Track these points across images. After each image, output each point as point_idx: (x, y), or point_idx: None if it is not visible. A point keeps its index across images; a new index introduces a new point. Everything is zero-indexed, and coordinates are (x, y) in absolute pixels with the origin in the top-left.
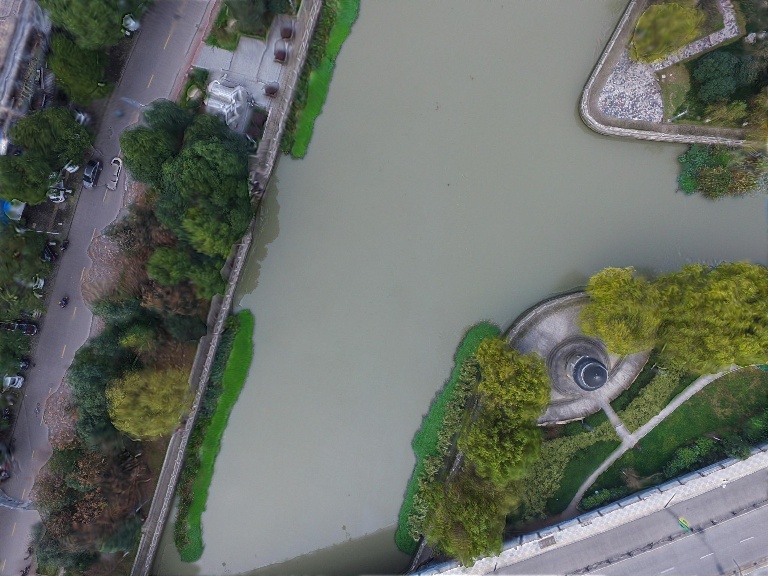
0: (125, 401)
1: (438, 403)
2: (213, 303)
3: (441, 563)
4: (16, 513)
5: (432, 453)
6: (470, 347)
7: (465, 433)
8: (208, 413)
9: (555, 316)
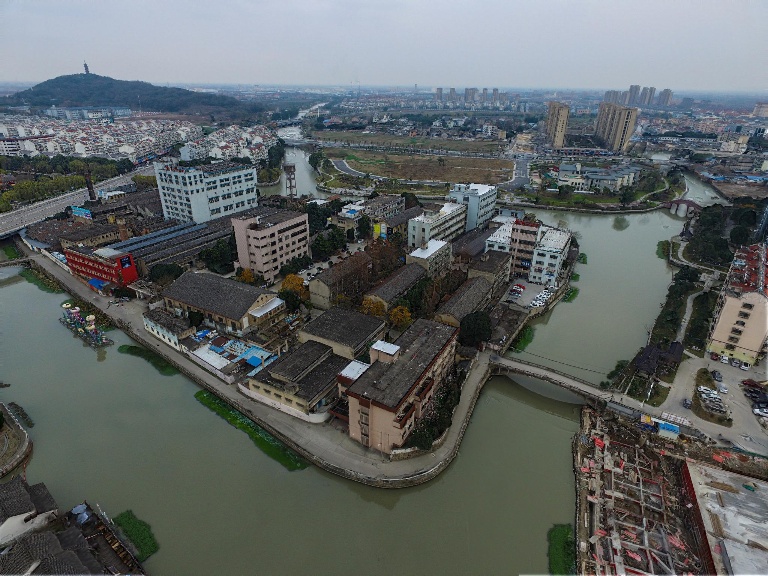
0: None
1: None
2: None
3: None
4: None
5: None
6: None
7: None
8: None
9: None
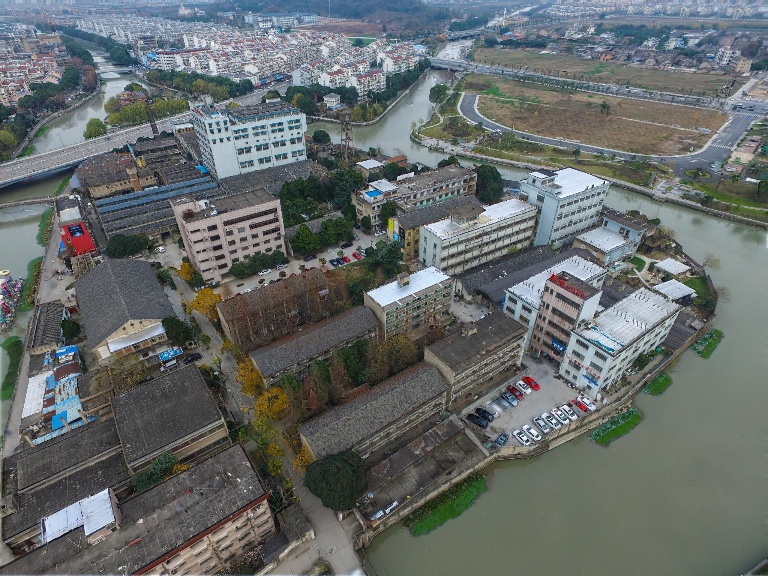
0: None
1: None
2: None
3: None
4: None
5: None
6: None
7: None
8: None
9: (109, 130)
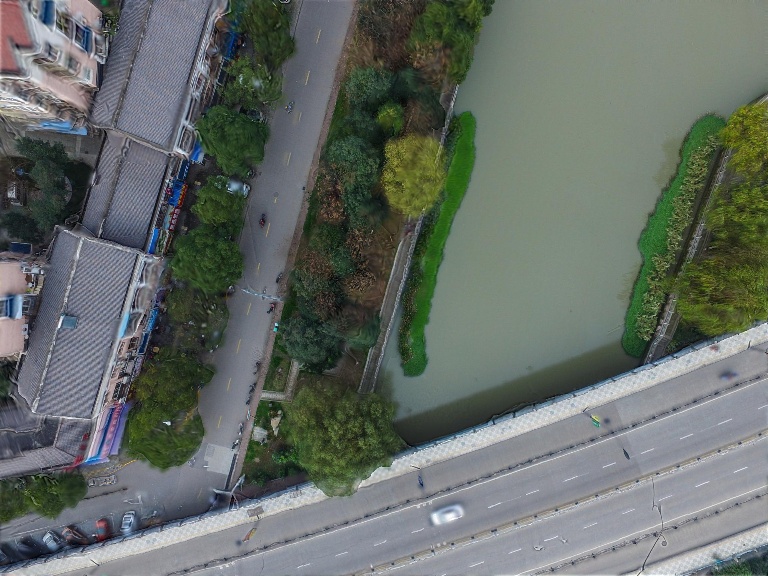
0: (405, 159)
1: (664, 201)
2: (441, 102)
3: (695, 342)
4: (241, 329)
5: (660, 251)
6: (696, 141)
7: (725, 201)
8: (433, 220)
9: None
